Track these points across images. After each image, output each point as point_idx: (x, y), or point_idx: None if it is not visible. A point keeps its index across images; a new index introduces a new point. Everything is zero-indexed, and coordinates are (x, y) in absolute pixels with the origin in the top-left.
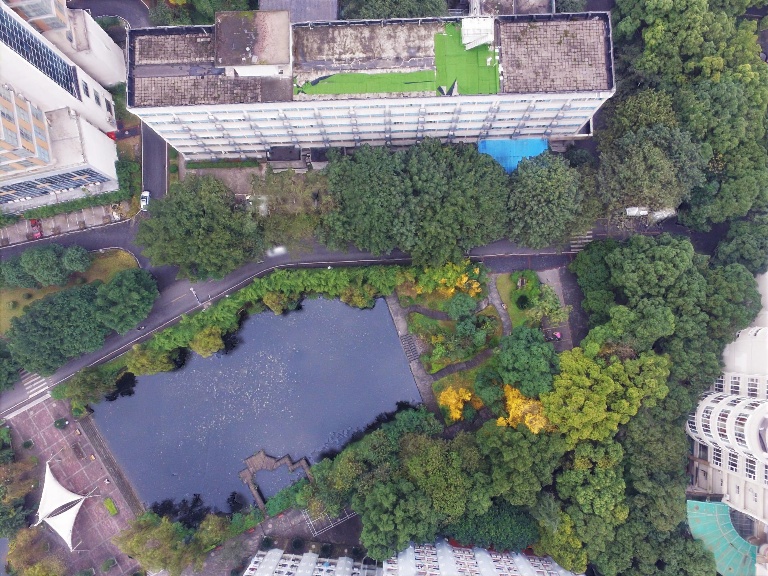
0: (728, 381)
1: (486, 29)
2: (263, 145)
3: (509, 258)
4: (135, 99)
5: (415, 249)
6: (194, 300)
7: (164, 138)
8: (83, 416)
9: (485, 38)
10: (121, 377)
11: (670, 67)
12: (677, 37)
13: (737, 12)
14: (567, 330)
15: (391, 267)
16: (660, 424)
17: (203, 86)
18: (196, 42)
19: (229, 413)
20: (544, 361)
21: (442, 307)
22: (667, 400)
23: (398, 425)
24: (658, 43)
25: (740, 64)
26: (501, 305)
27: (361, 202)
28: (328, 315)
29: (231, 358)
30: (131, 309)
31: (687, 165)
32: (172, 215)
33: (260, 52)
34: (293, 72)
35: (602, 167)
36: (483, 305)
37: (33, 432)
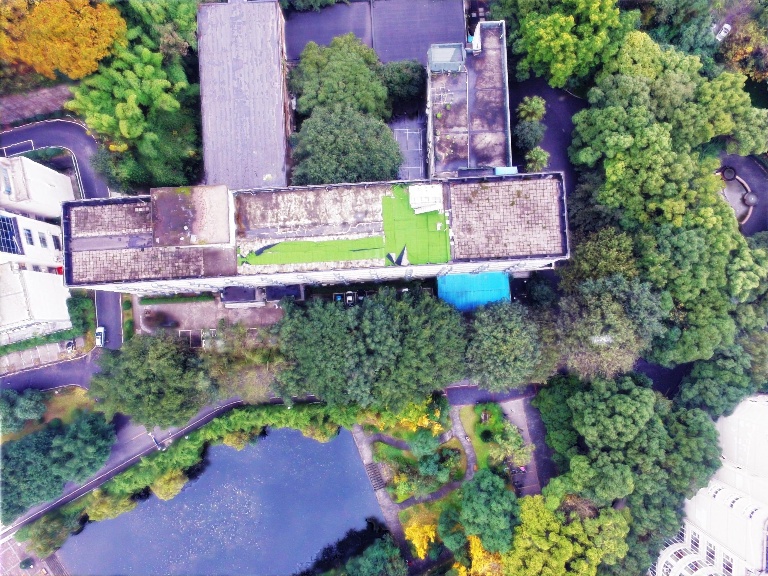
0: (689, 533)
1: (434, 197)
2: None
3: (472, 389)
4: (73, 275)
5: (371, 406)
6: (155, 437)
7: None
8: (49, 555)
9: (433, 206)
10: (85, 513)
11: (632, 205)
12: (638, 177)
13: (702, 141)
14: (532, 461)
15: (352, 405)
16: None
17: (143, 259)
18: (134, 212)
19: (195, 547)
20: (503, 519)
21: (406, 437)
22: (626, 559)
23: (361, 571)
24: (619, 179)
25: (703, 206)
26: (465, 438)
27: (313, 365)
28: (292, 445)
29: (195, 491)
30: (87, 462)
31: (646, 322)
32: (120, 382)
33: (199, 231)
34: (236, 241)
35: (562, 313)
36: (447, 437)
37: None
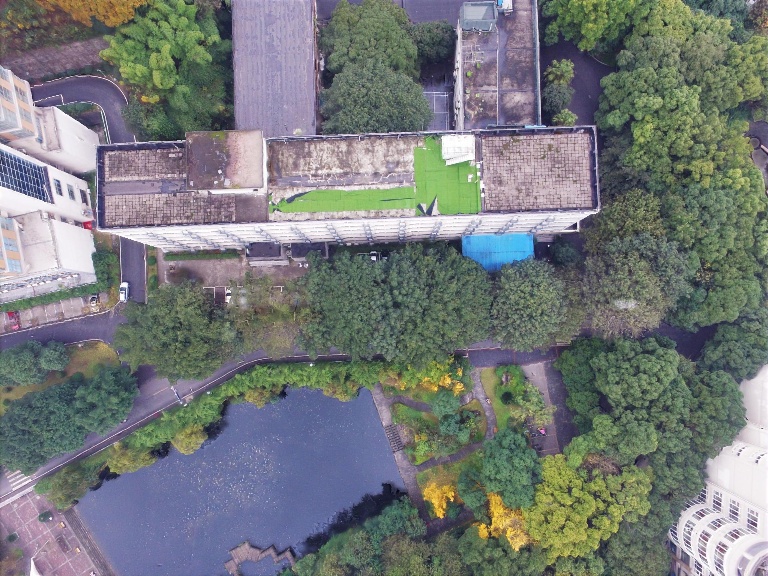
0: (711, 493)
1: (467, 147)
2: (242, 242)
3: (494, 352)
4: (106, 218)
5: (396, 360)
6: None
7: (139, 241)
8: (67, 508)
9: (466, 156)
10: (104, 468)
11: (659, 167)
12: (666, 138)
13: (730, 106)
14: (552, 425)
15: (374, 364)
16: (641, 540)
17: (175, 204)
18: (167, 157)
19: (213, 504)
20: (526, 475)
21: (426, 399)
22: (649, 516)
23: (381, 528)
24: (647, 141)
25: (731, 168)
26: (485, 400)
27: (340, 316)
28: (312, 405)
29: (215, 449)
30: (111, 413)
31: (673, 280)
32: (148, 329)
33: (233, 175)
34: (268, 189)
35: (587, 272)
36: (467, 399)
37: (18, 525)
